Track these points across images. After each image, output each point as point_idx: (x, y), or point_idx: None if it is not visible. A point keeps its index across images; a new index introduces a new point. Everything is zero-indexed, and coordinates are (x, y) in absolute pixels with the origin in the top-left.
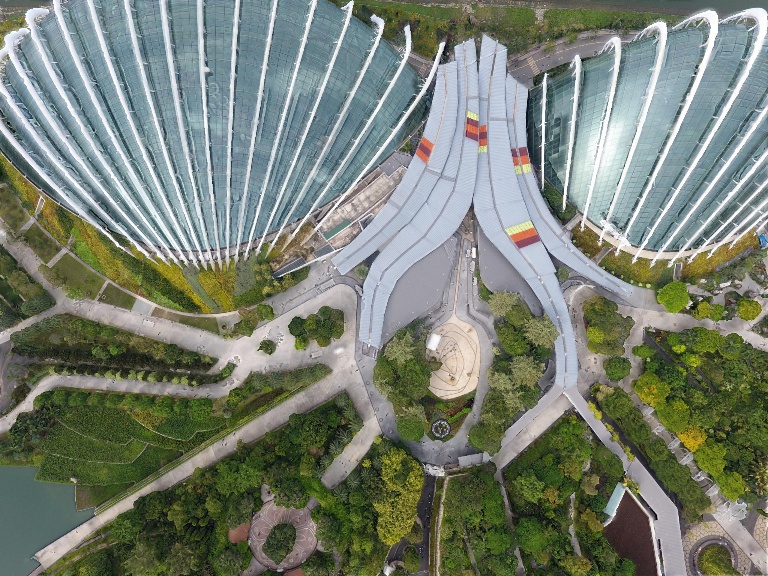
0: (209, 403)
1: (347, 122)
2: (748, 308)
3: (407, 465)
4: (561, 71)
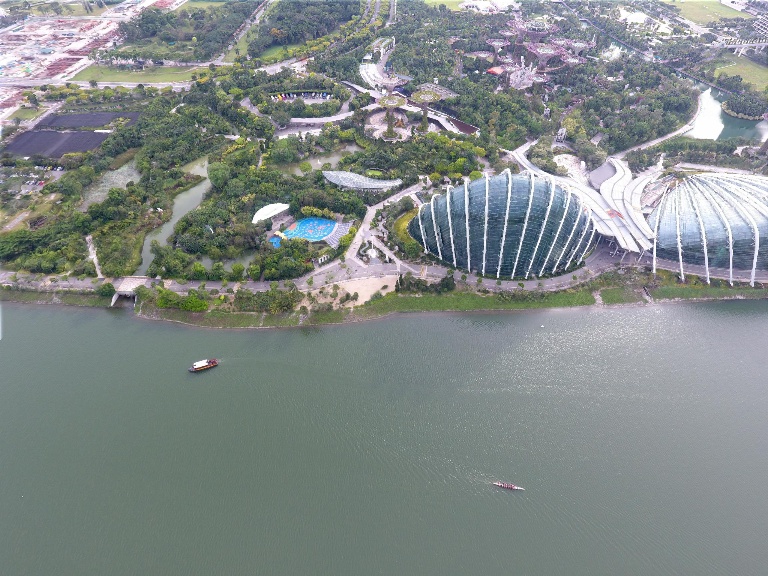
0: (667, 147)
1: (689, 206)
2: (437, 175)
3: (576, 132)
4: (570, 268)
